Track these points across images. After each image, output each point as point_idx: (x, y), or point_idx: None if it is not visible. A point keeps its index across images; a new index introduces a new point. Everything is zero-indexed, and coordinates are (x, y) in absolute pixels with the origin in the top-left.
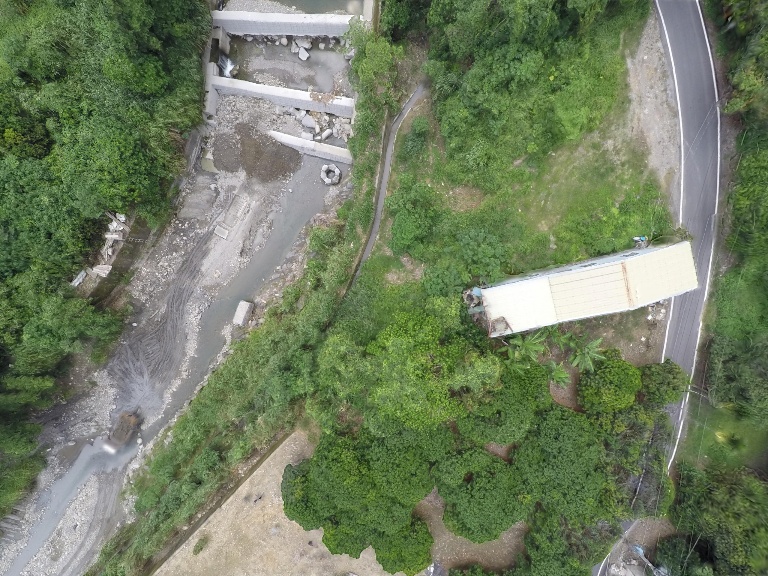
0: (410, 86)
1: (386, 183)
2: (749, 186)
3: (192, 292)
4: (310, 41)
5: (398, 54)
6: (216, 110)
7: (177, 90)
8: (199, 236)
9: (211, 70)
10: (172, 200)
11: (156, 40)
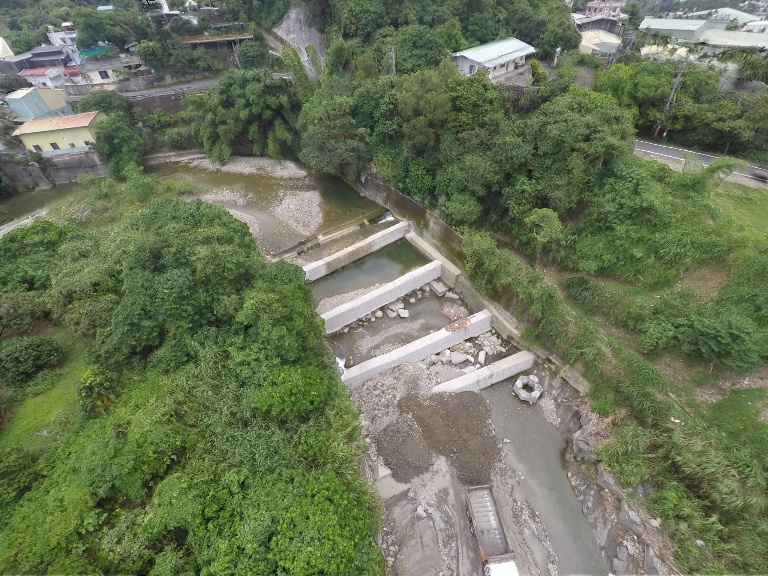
0: None
1: None
2: None
3: None
4: (401, 302)
5: None
6: None
7: (336, 389)
8: None
9: None
10: None
11: None
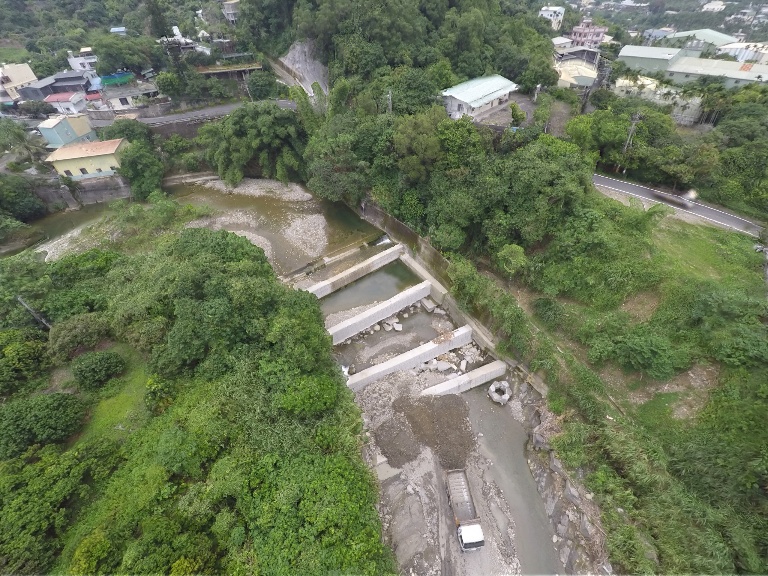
0: None
1: None
2: (759, 190)
3: None
4: (396, 317)
5: None
6: None
7: (343, 393)
8: None
9: None
10: None
11: None
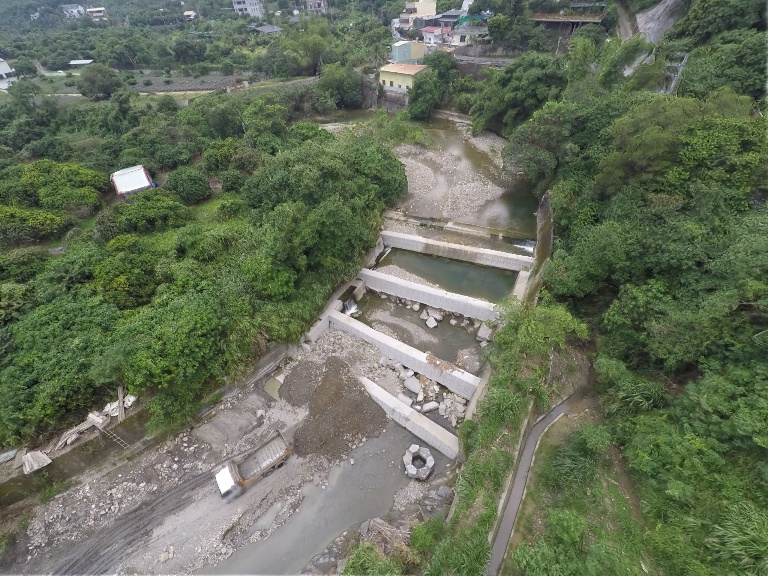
0: (564, 386)
1: (513, 514)
2: None
3: (105, 570)
4: (442, 315)
5: (580, 330)
6: (318, 338)
7: (294, 303)
8: (194, 472)
9: (335, 305)
10: (203, 408)
11: (305, 258)
